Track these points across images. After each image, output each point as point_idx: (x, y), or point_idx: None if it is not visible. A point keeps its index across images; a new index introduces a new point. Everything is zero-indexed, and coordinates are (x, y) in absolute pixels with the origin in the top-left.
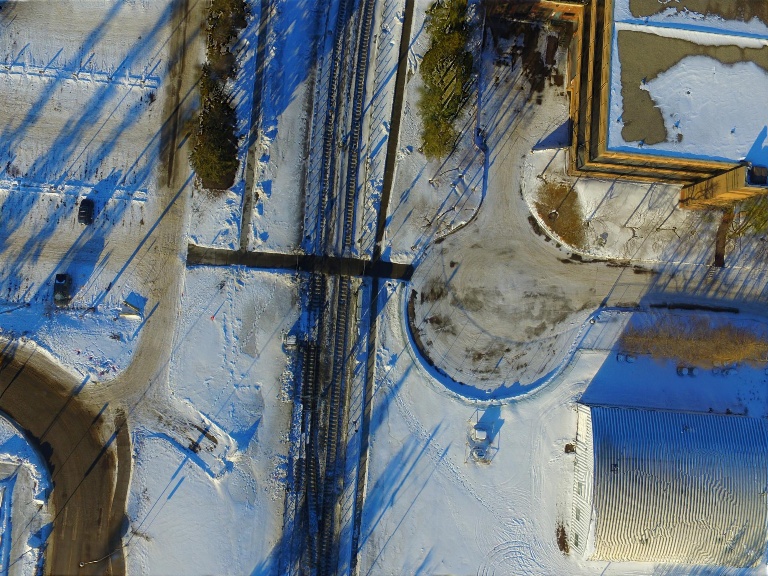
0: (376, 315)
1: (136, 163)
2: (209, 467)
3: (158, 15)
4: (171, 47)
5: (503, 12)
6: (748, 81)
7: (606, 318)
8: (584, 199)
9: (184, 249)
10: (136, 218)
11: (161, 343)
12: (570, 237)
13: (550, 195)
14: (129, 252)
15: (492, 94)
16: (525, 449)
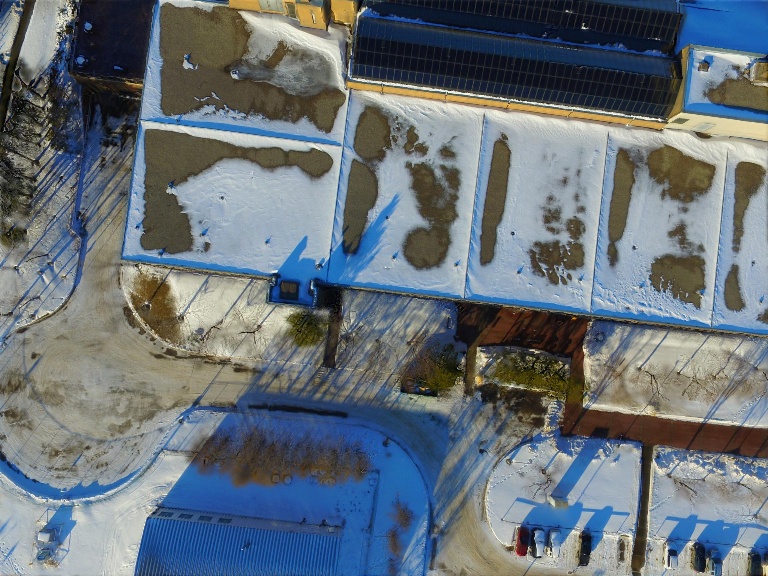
0: None
1: None
2: None
3: None
4: None
5: (110, 89)
6: (290, 187)
7: (197, 418)
8: (177, 292)
9: None
10: None
11: None
12: (164, 331)
13: (143, 286)
14: None
15: (96, 176)
16: (97, 553)
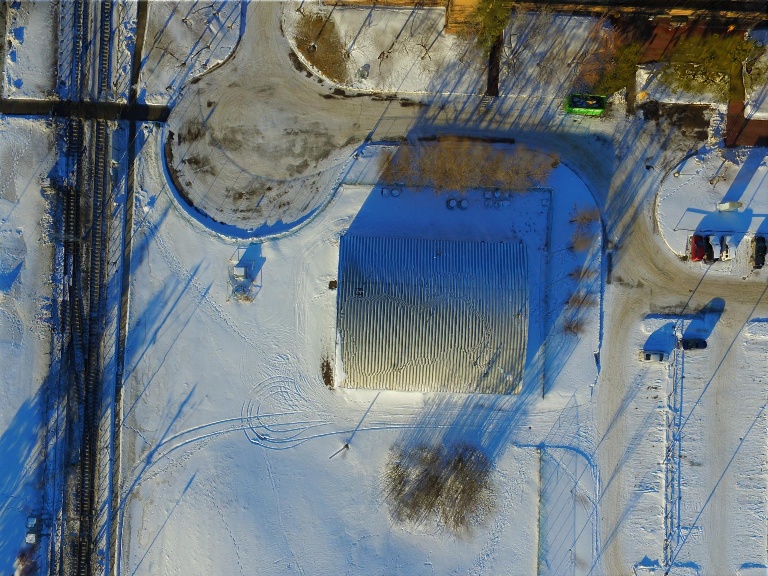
0: (134, 158)
1: None
2: None
3: None
4: None
5: None
6: None
7: (370, 153)
8: (342, 29)
9: None
10: None
11: None
12: (331, 71)
13: (307, 28)
14: None
15: None
16: (288, 286)
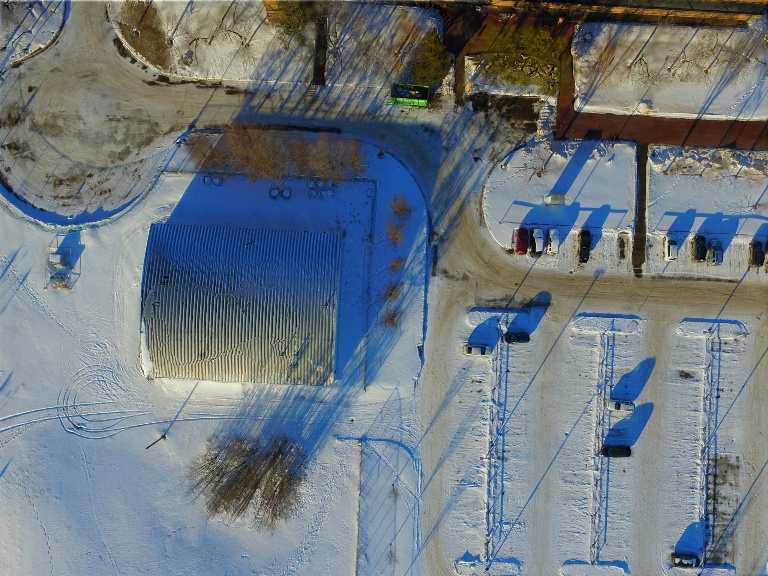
0: None
1: None
2: None
3: None
4: None
5: None
6: None
7: (193, 140)
8: (164, 15)
9: None
10: None
11: None
12: (154, 57)
13: (130, 13)
14: None
15: None
16: (107, 274)
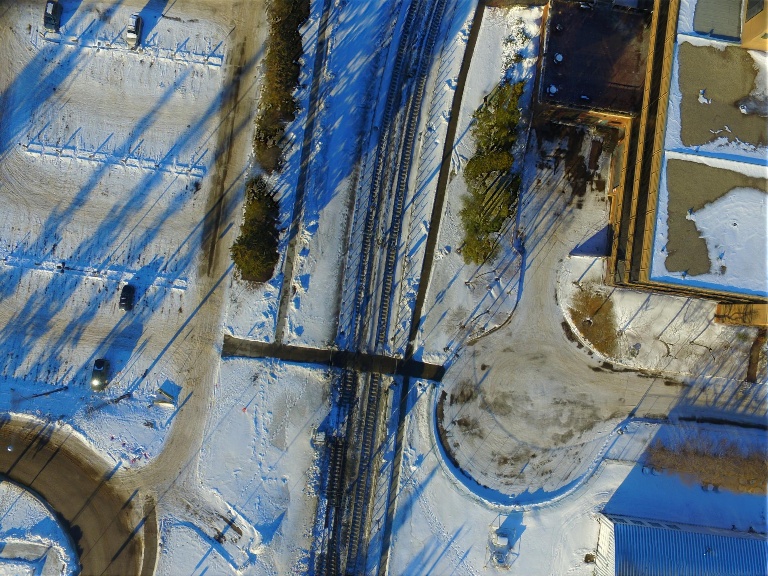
0: (405, 414)
1: (178, 251)
2: (233, 558)
3: (208, 104)
4: (219, 137)
5: (549, 115)
6: None
7: (634, 429)
8: (619, 309)
9: (220, 339)
10: (175, 306)
11: (193, 432)
12: (603, 346)
13: (585, 303)
14: (166, 340)
15: (533, 197)
16: (545, 556)
